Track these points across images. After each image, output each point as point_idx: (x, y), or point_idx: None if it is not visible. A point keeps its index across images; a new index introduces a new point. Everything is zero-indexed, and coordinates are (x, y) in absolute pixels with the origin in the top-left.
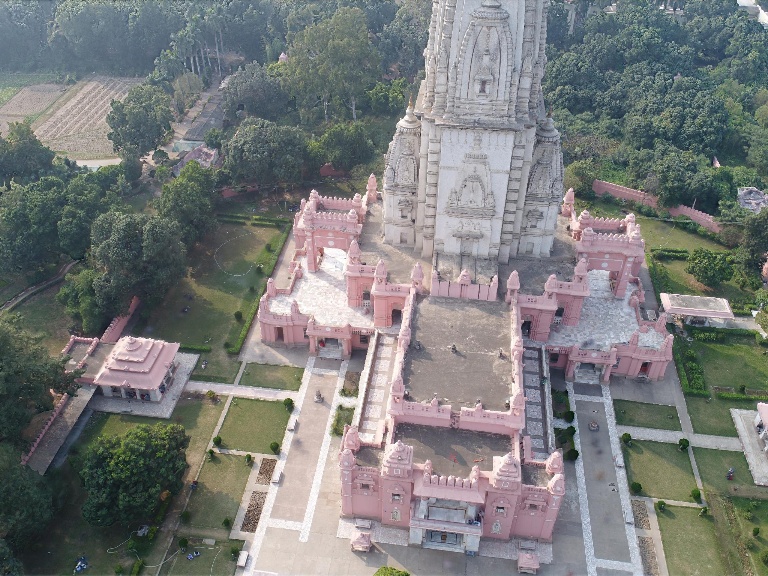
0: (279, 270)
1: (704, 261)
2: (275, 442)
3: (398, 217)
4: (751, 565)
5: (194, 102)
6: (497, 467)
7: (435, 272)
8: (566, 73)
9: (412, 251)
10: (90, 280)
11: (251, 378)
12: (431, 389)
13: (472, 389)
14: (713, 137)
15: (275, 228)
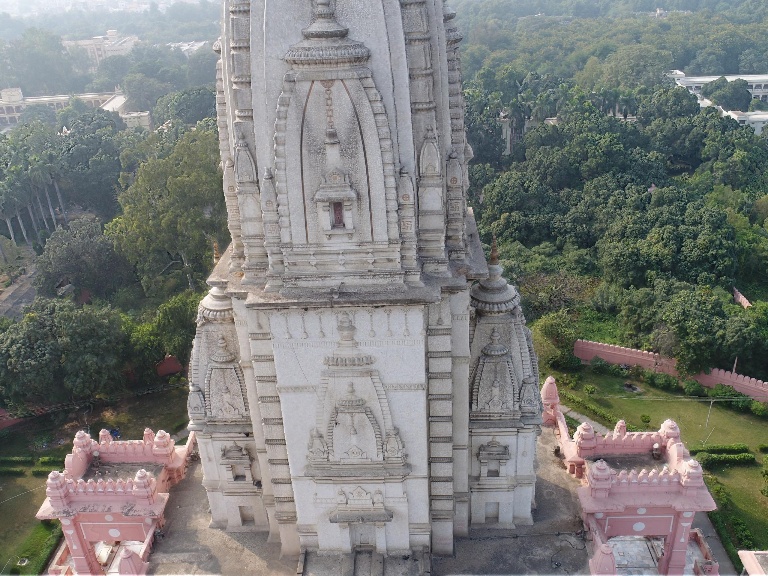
0: None
1: None
2: None
3: (227, 480)
4: None
5: (15, 278)
6: None
7: None
8: (510, 196)
9: (264, 541)
10: None
11: None
12: None
13: None
14: (728, 261)
15: None
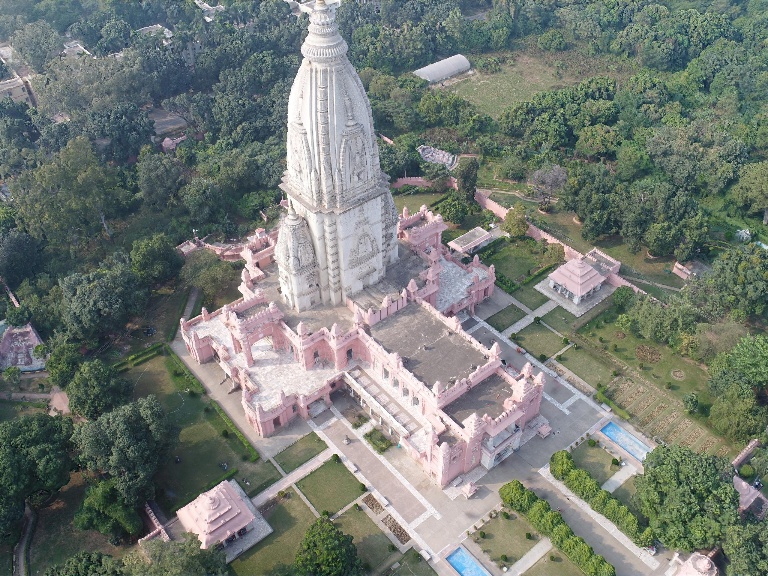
0: (205, 384)
1: (452, 210)
2: (362, 484)
3: (307, 289)
4: (612, 356)
5: None
6: (521, 390)
7: (371, 309)
8: (237, 113)
9: (324, 306)
10: (106, 491)
11: (289, 464)
12: (442, 378)
13: (459, 362)
14: (374, 121)
15: (157, 356)
